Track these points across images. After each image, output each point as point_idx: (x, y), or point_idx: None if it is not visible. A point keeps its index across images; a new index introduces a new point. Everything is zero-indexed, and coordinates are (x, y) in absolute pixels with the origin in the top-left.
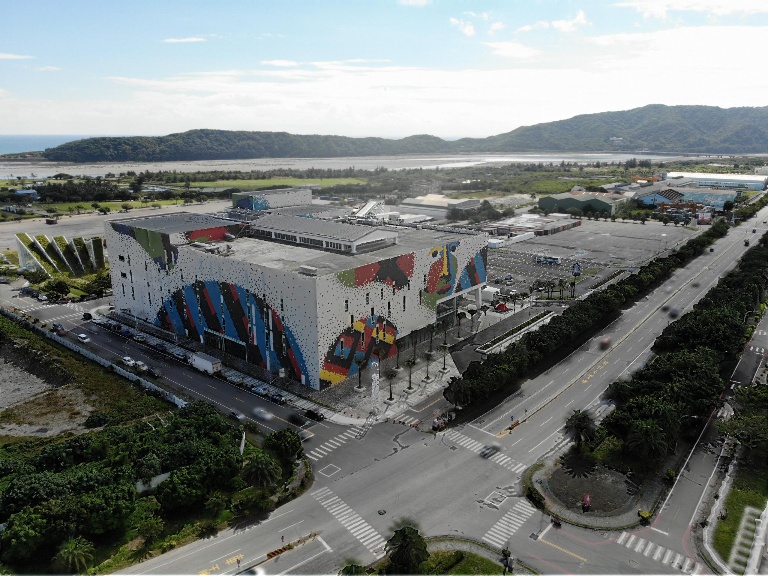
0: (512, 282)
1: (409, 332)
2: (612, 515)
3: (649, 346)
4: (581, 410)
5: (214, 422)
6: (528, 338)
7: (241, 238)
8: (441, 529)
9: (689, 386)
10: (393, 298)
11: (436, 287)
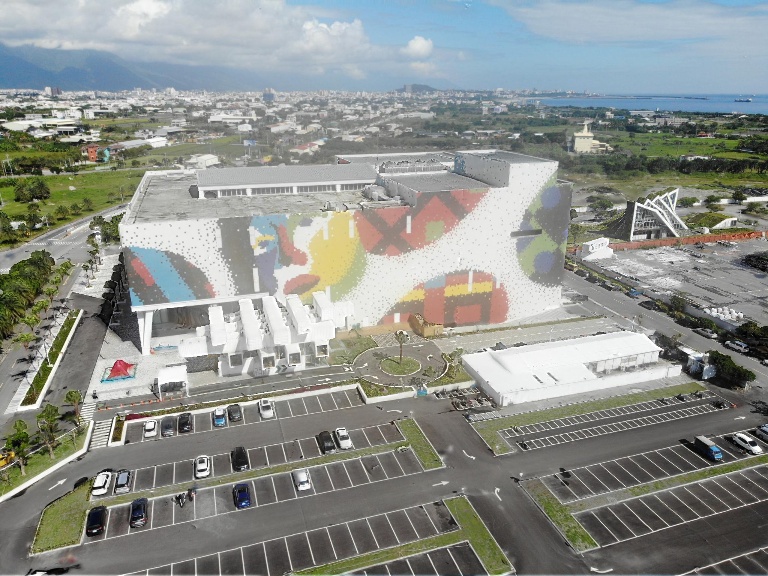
0: None
1: None
2: None
3: None
4: None
5: None
6: None
7: None
8: None
9: None
10: None
11: None
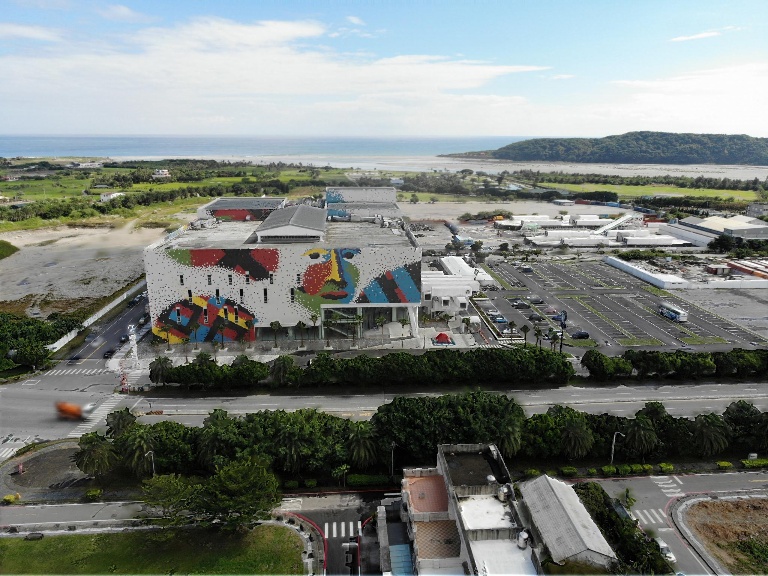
0: (542, 322)
1: None
2: (9, 486)
3: None
4: None
5: None
6: (318, 359)
7: (258, 221)
8: None
9: (216, 434)
10: (248, 287)
11: (320, 290)
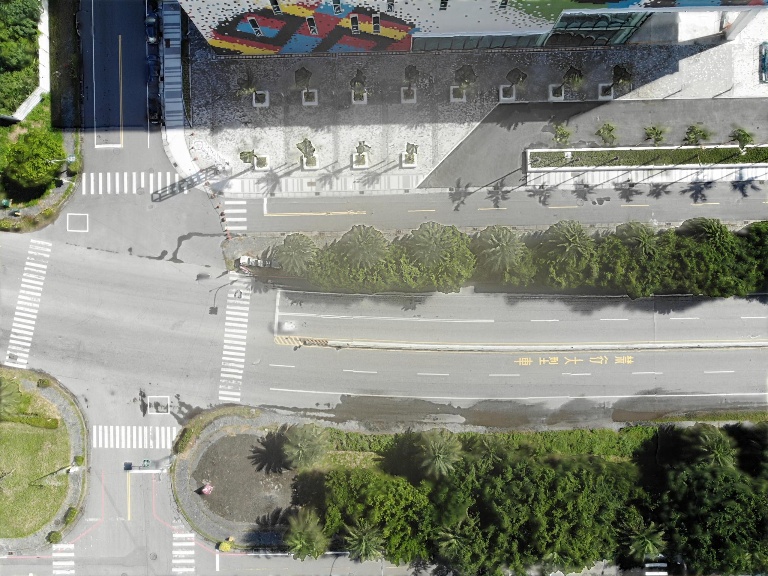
0: None
1: (454, 33)
2: (209, 517)
3: (763, 394)
4: (424, 396)
5: (1, 52)
6: (560, 240)
7: None
8: (77, 386)
9: None
10: None
11: None
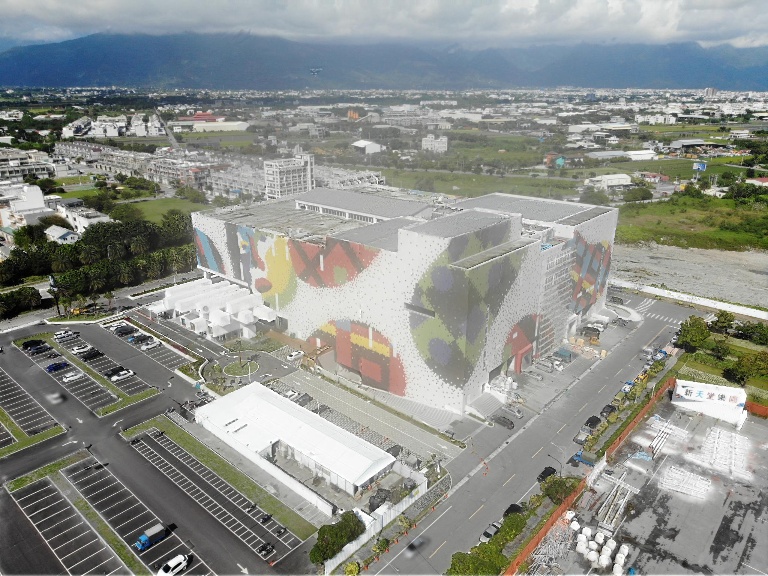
0: None
1: None
2: None
3: None
4: None
5: None
6: None
7: None
8: None
9: None
10: None
11: None
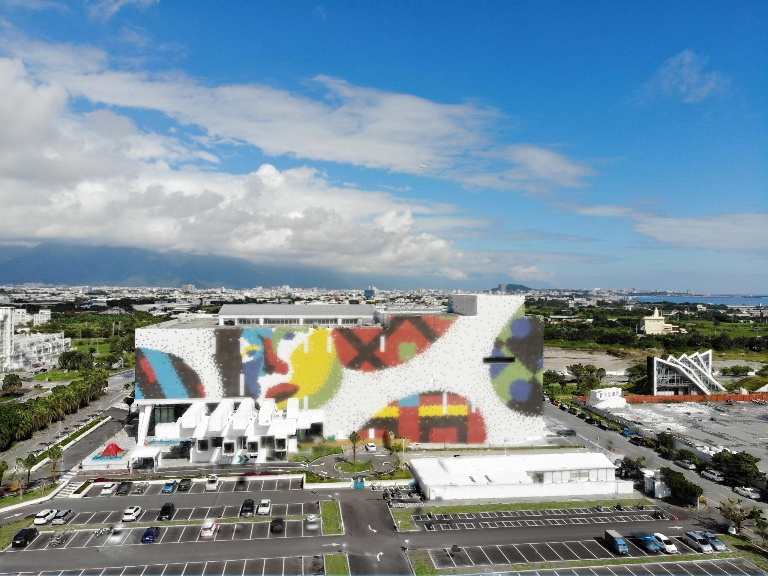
0: None
1: None
2: None
3: None
4: None
5: None
6: None
7: None
8: None
9: None
10: None
11: None
